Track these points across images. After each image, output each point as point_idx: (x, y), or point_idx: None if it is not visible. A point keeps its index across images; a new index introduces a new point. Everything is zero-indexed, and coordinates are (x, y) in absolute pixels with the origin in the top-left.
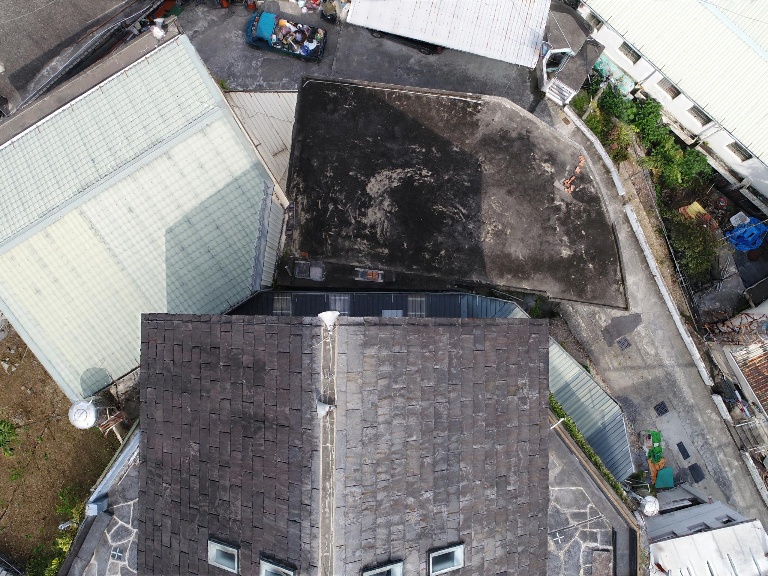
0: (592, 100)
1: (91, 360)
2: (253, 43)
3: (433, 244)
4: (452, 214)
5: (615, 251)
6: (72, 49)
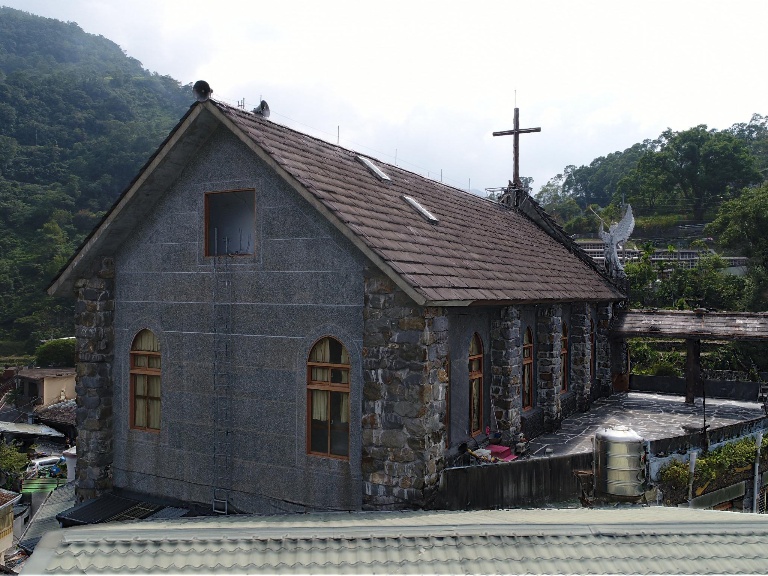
0: None
1: None
2: None
3: None
4: None
5: None
6: None
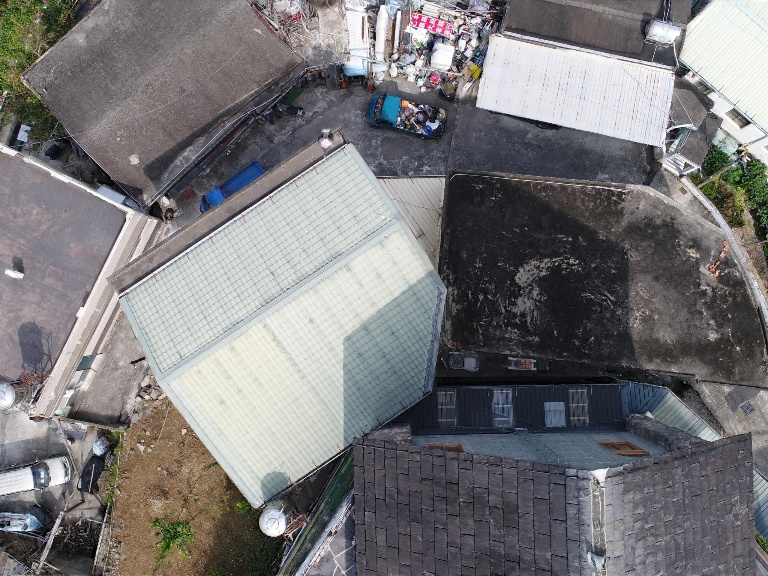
0: (715, 174)
1: (271, 465)
2: (376, 124)
3: (582, 331)
4: (600, 301)
5: (761, 333)
6: (204, 139)
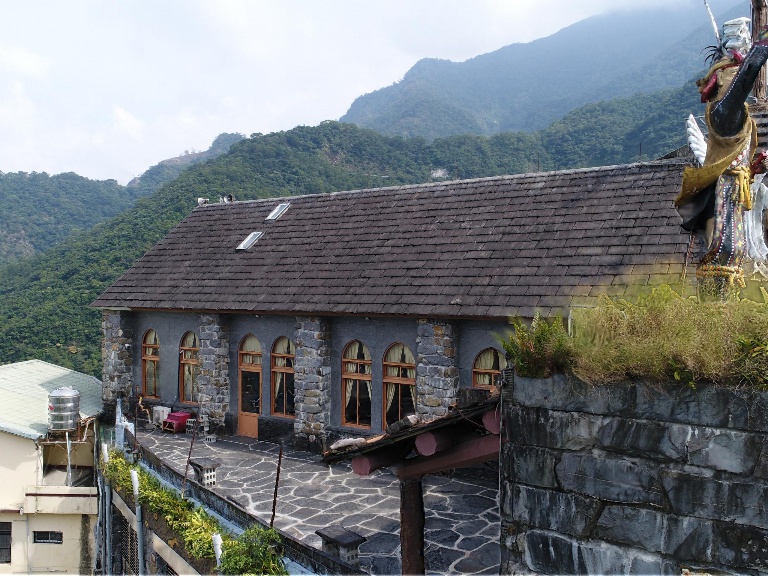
0: None
1: (30, 421)
2: None
3: None
4: None
5: None
6: None
